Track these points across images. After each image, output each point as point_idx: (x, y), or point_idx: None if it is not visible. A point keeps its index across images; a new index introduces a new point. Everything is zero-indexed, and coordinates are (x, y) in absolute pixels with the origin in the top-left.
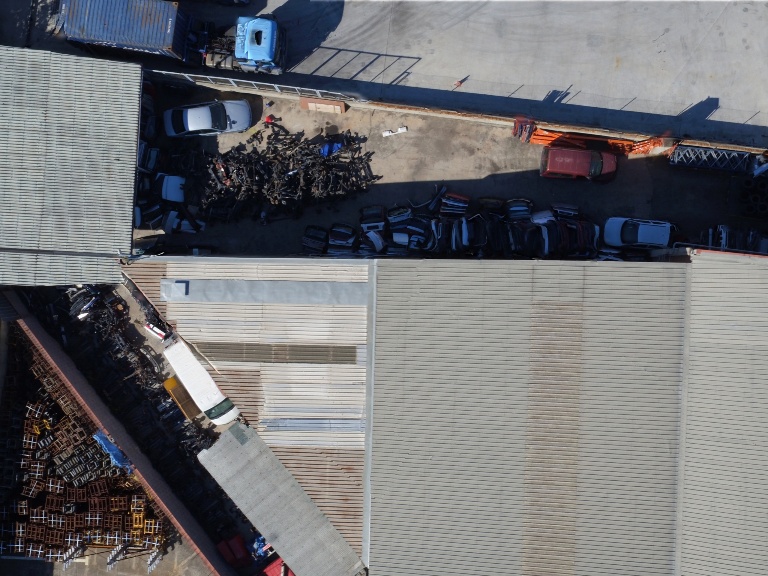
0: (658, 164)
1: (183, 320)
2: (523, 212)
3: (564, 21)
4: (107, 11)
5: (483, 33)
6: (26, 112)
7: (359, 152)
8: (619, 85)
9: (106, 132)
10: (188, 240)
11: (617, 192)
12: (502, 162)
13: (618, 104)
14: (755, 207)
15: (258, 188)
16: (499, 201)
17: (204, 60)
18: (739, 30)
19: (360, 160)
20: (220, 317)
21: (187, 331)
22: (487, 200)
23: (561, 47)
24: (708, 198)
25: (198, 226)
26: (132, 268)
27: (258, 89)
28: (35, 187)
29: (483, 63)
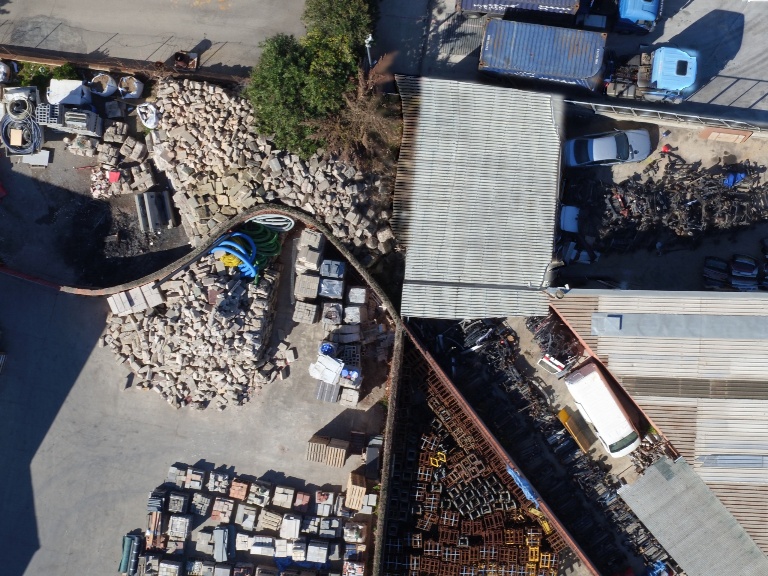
0: None
1: (616, 355)
2: None
3: None
4: (533, 41)
5: None
6: (434, 142)
7: (758, 182)
8: None
9: (519, 163)
10: (585, 271)
11: None
12: None
13: None
14: None
15: (659, 219)
16: None
17: (605, 89)
18: None
19: (760, 190)
20: (655, 352)
21: (618, 366)
22: None
23: None
24: None
25: (594, 257)
26: (564, 302)
27: (661, 118)
28: (438, 218)
29: None
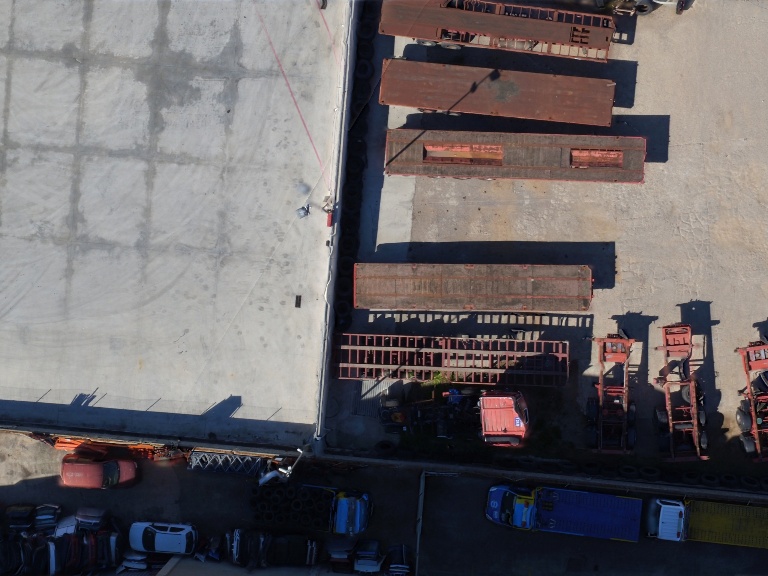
0: (182, 465)
1: None
2: (48, 520)
3: (86, 326)
4: None
5: (8, 340)
6: None
7: None
8: (143, 386)
9: None
10: None
11: (145, 493)
12: (33, 467)
13: (143, 405)
14: (261, 516)
15: None
16: (29, 508)
17: None
18: (256, 329)
19: None
20: None
21: None
22: (15, 508)
23: (85, 351)
24: (232, 498)
25: None
26: None
27: None
28: None
29: (10, 370)
